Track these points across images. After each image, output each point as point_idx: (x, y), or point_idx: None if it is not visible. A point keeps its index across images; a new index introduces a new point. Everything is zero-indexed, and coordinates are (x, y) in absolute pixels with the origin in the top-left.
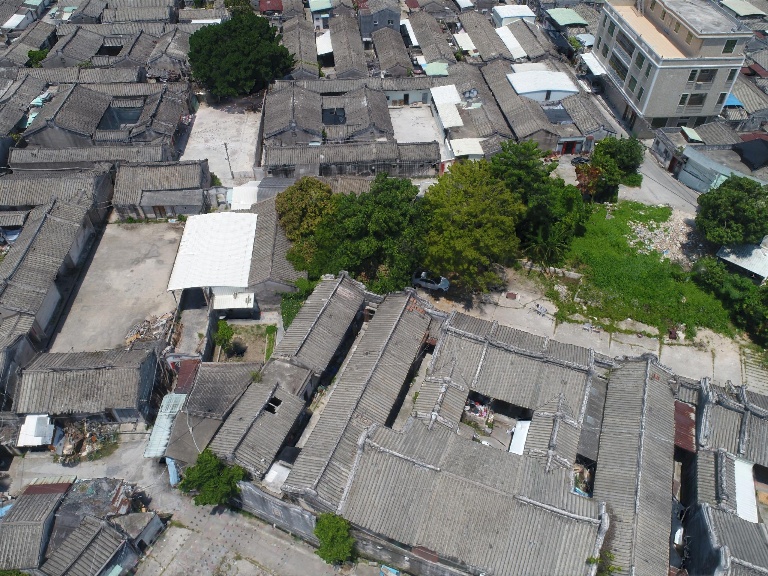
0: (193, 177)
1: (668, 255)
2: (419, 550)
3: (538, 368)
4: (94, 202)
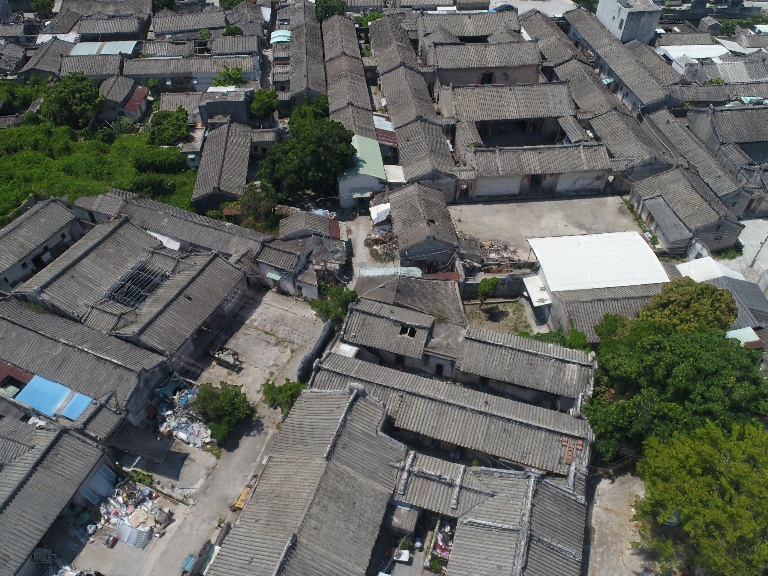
0: (701, 221)
1: None
2: None
3: None
4: (627, 172)
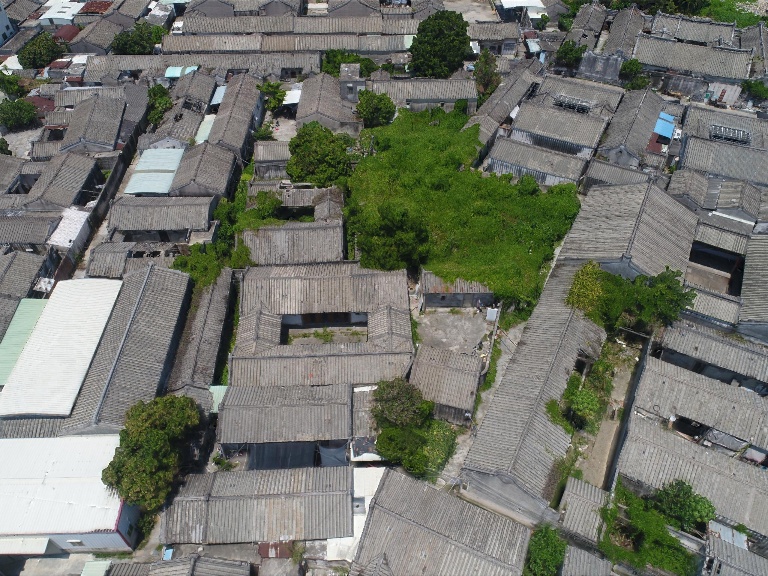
0: None
1: (759, 14)
2: (670, 72)
3: (707, 27)
4: None
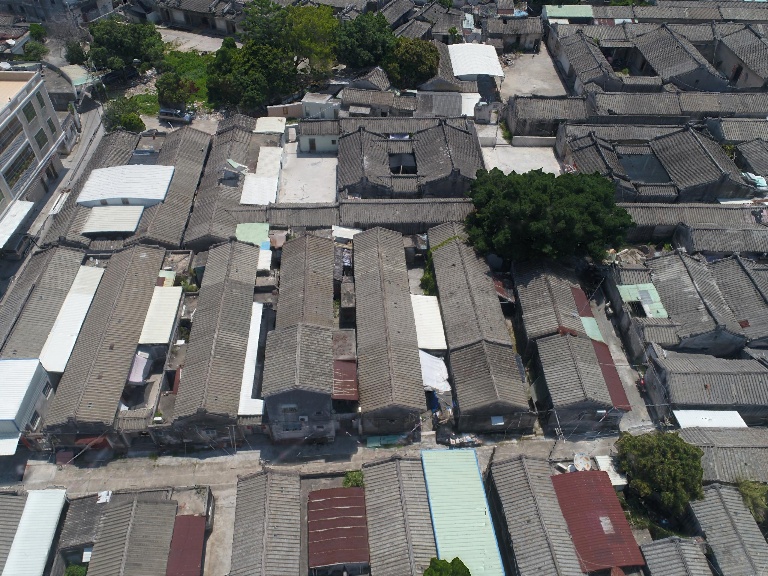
0: None
1: None
2: None
3: None
4: None
